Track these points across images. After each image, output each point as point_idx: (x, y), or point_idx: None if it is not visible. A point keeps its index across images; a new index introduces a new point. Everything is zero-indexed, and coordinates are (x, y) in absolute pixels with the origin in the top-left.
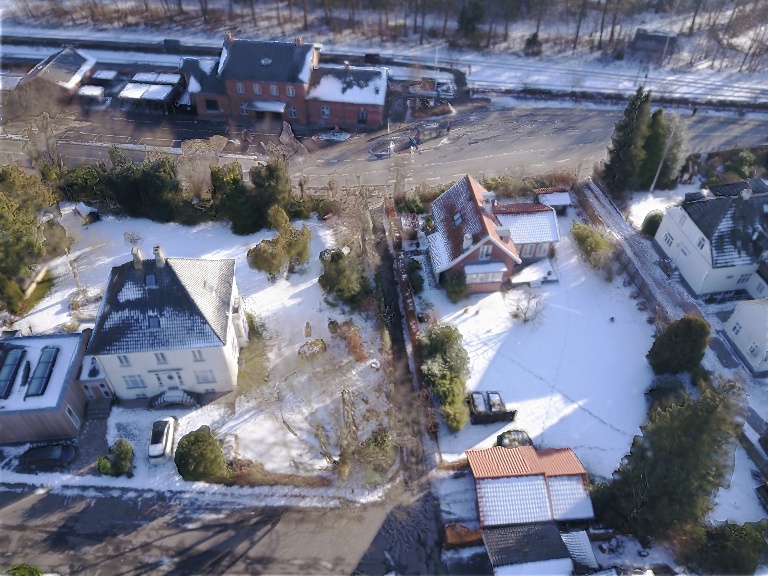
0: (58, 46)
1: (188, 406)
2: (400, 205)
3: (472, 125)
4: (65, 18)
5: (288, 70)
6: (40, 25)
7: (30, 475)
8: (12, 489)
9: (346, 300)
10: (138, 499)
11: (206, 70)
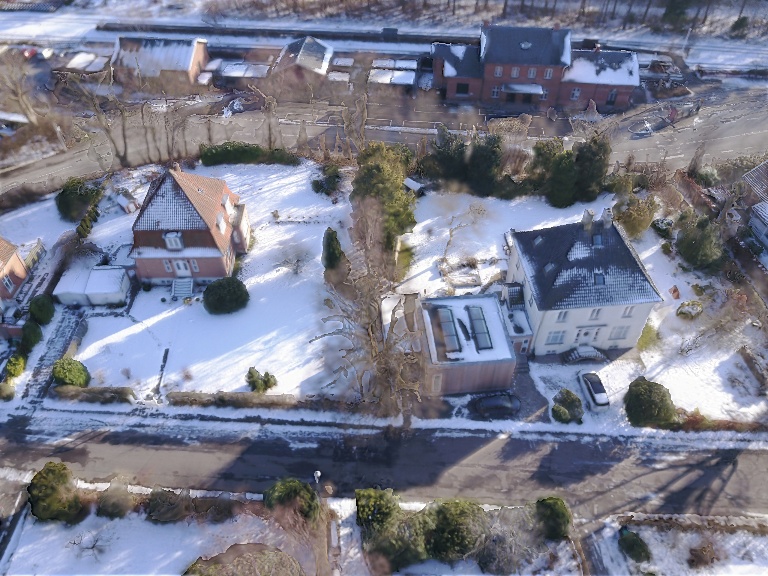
0: (277, 36)
1: (599, 361)
2: (694, 179)
3: (715, 105)
4: (266, 10)
5: (549, 53)
6: (247, 17)
7: (485, 422)
8: (476, 434)
9: (704, 265)
10: (596, 443)
11: (458, 55)
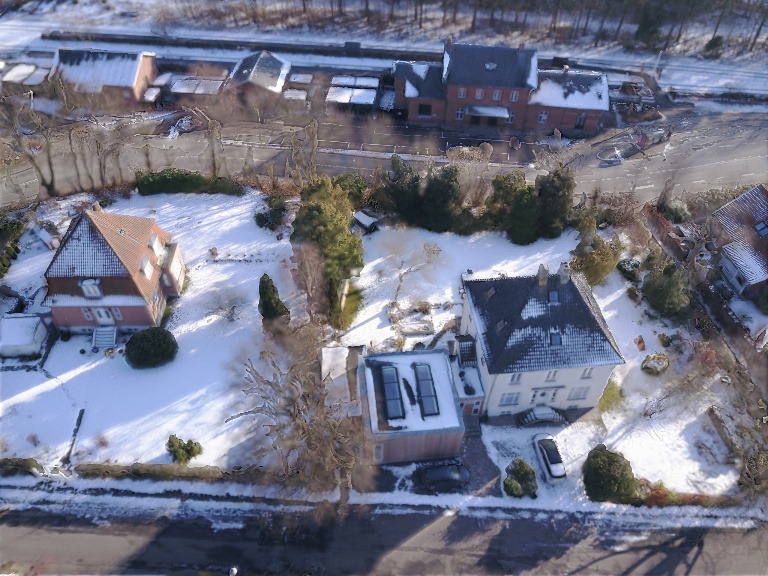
0: (234, 48)
1: (557, 423)
2: (664, 213)
3: (687, 130)
4: (225, 19)
5: (515, 75)
6: (203, 26)
7: (431, 496)
8: (419, 511)
9: (671, 313)
10: (551, 521)
11: (421, 74)
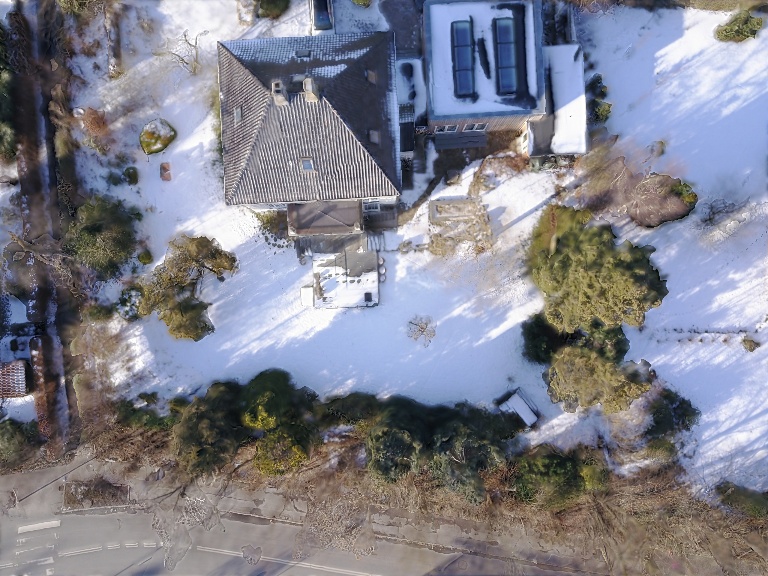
0: None
1: None
2: (33, 439)
3: None
4: None
5: None
6: None
7: None
8: None
9: None
10: None
11: None
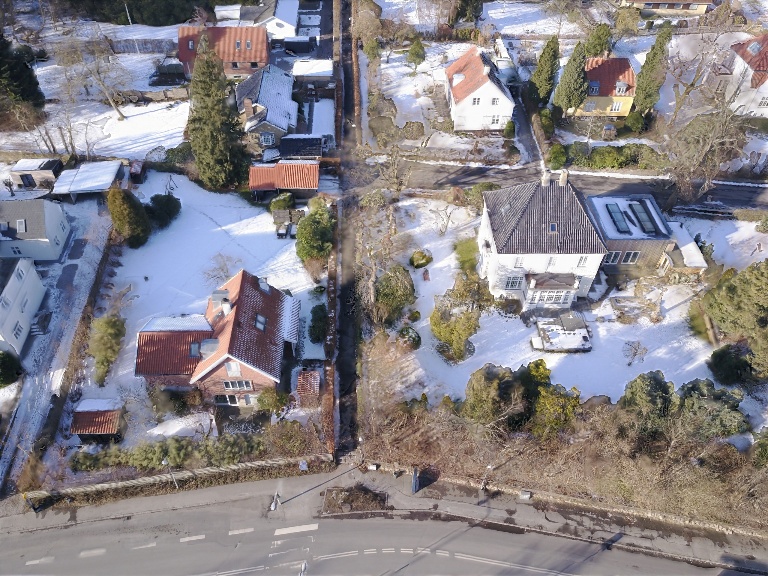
0: None
1: None
2: None
3: None
4: None
5: None
6: None
7: None
8: None
9: None
10: None
11: None
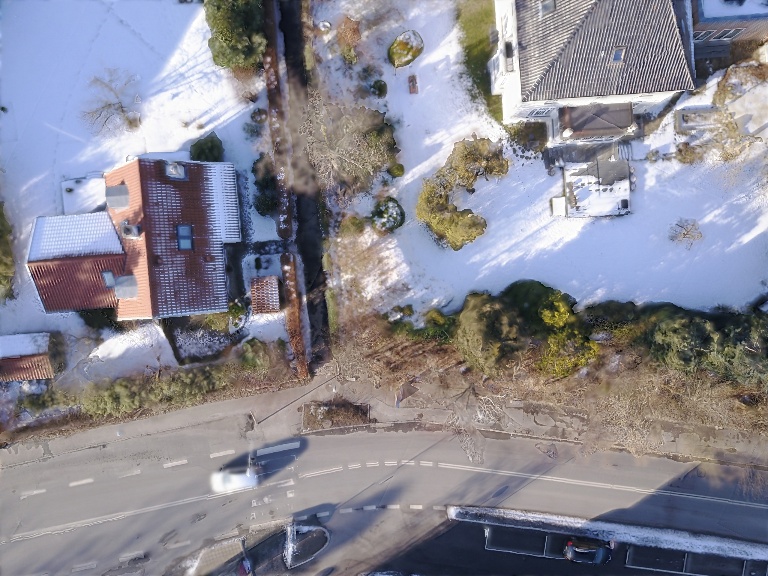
0: None
1: None
2: (280, 357)
3: None
4: None
5: None
6: None
7: None
8: None
9: None
10: None
11: None
